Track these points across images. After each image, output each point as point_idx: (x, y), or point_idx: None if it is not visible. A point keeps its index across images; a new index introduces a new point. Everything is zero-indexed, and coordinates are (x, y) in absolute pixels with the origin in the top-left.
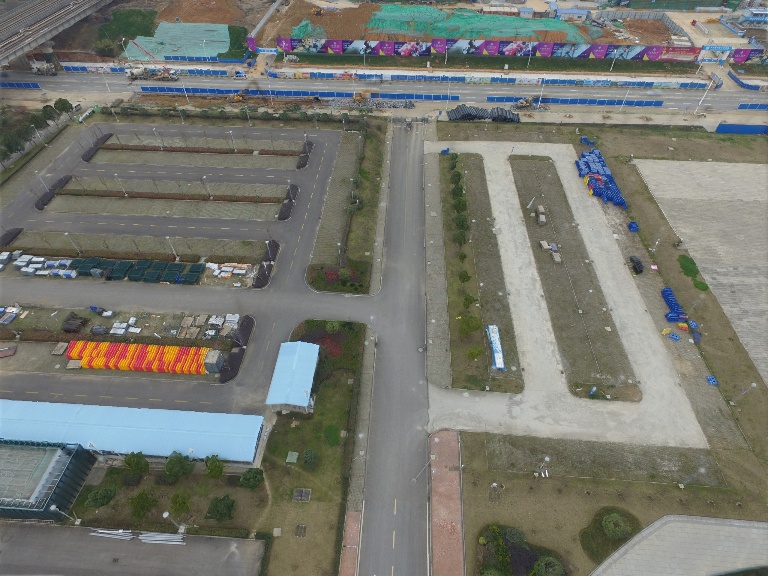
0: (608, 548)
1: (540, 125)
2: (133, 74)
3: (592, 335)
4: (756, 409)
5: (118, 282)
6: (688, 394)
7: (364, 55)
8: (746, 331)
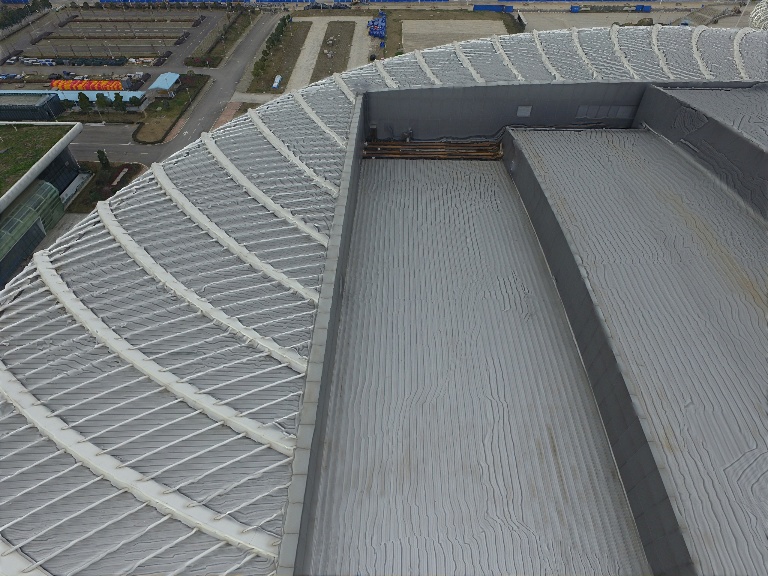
0: None
1: None
2: None
3: None
4: None
5: (79, 66)
6: None
7: None
8: None
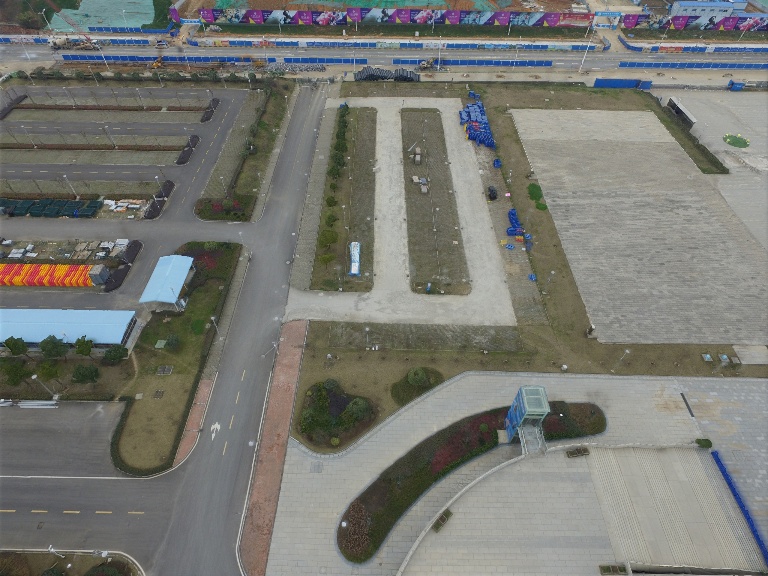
0: (412, 395)
1: (436, 83)
2: (56, 44)
3: (440, 247)
4: (561, 295)
5: (20, 218)
6: (510, 288)
7: (279, 23)
8: (569, 239)
